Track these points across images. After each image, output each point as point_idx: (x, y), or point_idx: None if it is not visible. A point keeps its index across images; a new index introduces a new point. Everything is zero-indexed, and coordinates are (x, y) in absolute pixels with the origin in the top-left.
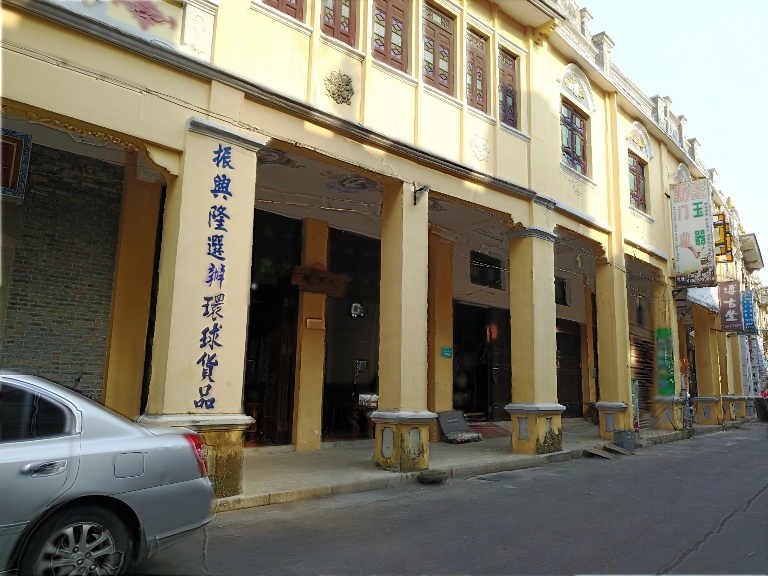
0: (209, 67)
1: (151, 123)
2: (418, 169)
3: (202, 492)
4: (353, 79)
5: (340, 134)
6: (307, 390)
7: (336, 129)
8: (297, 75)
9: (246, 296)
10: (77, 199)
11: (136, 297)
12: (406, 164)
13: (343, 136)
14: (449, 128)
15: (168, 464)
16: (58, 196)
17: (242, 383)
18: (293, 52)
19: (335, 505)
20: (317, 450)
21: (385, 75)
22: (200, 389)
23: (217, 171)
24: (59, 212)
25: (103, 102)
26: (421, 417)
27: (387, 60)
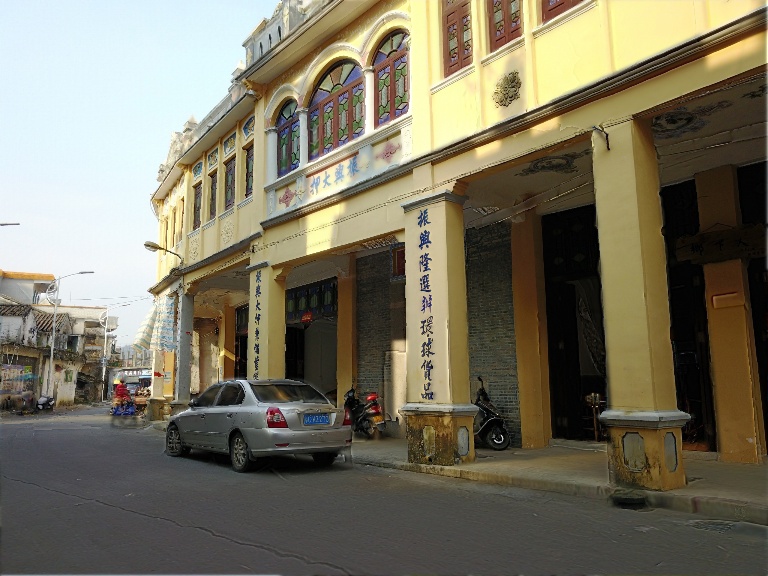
0: (406, 164)
1: (391, 220)
2: (612, 101)
3: (266, 435)
4: (520, 69)
5: (506, 136)
6: (726, 385)
7: (500, 135)
8: (470, 113)
9: (446, 314)
10: (492, 254)
11: (528, 314)
12: (591, 109)
13: (510, 136)
14: (669, 2)
15: (255, 419)
16: (483, 256)
17: (449, 381)
18: (465, 97)
19: (484, 490)
20: (747, 464)
21: (555, 30)
22: (424, 386)
23: (421, 230)
24: (484, 267)
25: (373, 222)
26: (631, 419)
27: (567, 5)
